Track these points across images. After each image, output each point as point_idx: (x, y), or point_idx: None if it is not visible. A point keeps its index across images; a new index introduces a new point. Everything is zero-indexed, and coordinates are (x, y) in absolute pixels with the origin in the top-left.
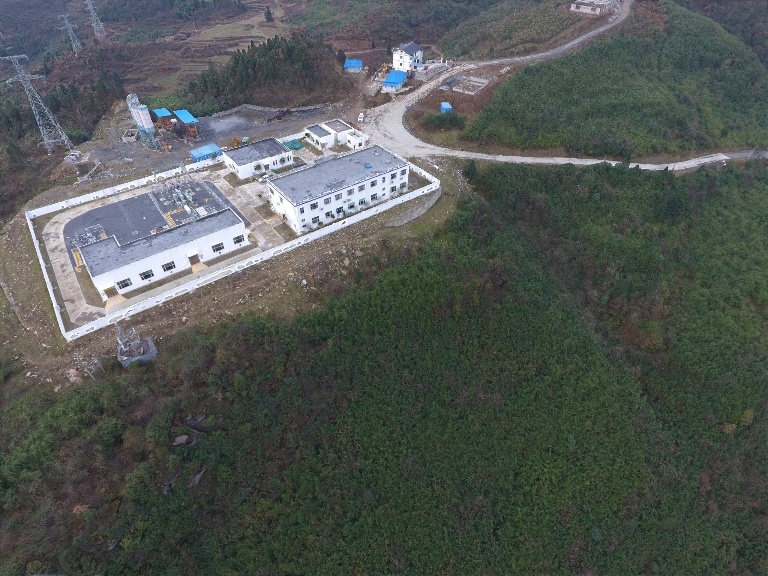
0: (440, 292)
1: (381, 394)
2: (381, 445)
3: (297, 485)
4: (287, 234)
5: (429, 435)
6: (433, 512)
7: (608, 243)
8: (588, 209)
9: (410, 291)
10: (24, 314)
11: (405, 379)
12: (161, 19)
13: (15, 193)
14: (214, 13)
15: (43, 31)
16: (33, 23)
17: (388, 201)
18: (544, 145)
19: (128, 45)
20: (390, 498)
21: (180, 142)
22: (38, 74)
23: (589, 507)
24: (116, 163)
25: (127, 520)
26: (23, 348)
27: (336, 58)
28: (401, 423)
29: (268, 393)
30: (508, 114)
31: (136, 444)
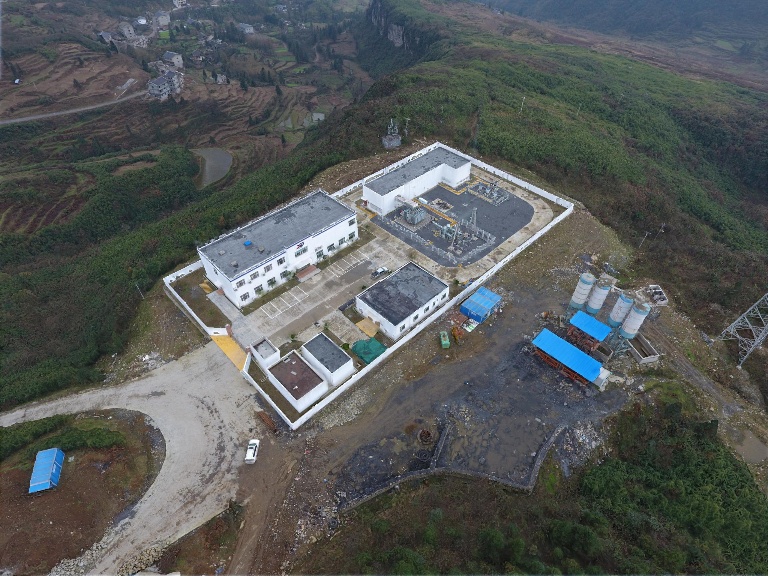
0: None
1: None
2: None
3: None
4: None
5: None
6: None
7: None
8: None
9: None
10: None
11: None
12: None
13: None
14: None
15: None
16: None
17: None
18: None
19: None
20: None
21: None
22: None
23: None
24: None
25: None
26: None
27: None
28: None
29: None
30: None
31: None
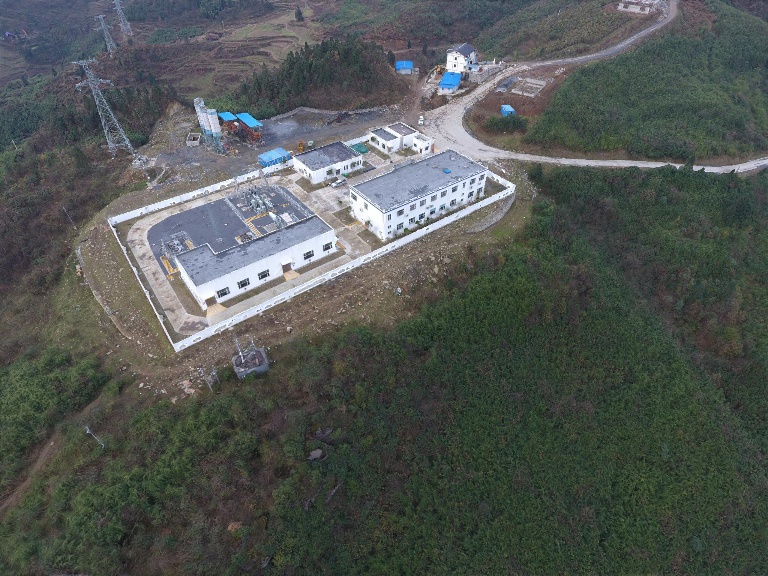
0: (531, 300)
1: (482, 404)
2: (488, 456)
3: (417, 498)
4: (372, 241)
5: (532, 445)
6: (544, 524)
7: (679, 248)
8: (655, 213)
9: (502, 299)
10: (123, 323)
11: (503, 388)
12: (187, 18)
13: (86, 198)
14: (241, 12)
15: (78, 32)
16: (67, 24)
17: (468, 207)
18: (607, 148)
19: (162, 45)
20: (503, 510)
21: (244, 146)
22: (74, 75)
23: (688, 517)
24: (184, 168)
25: (277, 537)
26: (129, 358)
27: (386, 59)
28: (505, 433)
29: (382, 404)
30: (569, 116)
31: (276, 459)
